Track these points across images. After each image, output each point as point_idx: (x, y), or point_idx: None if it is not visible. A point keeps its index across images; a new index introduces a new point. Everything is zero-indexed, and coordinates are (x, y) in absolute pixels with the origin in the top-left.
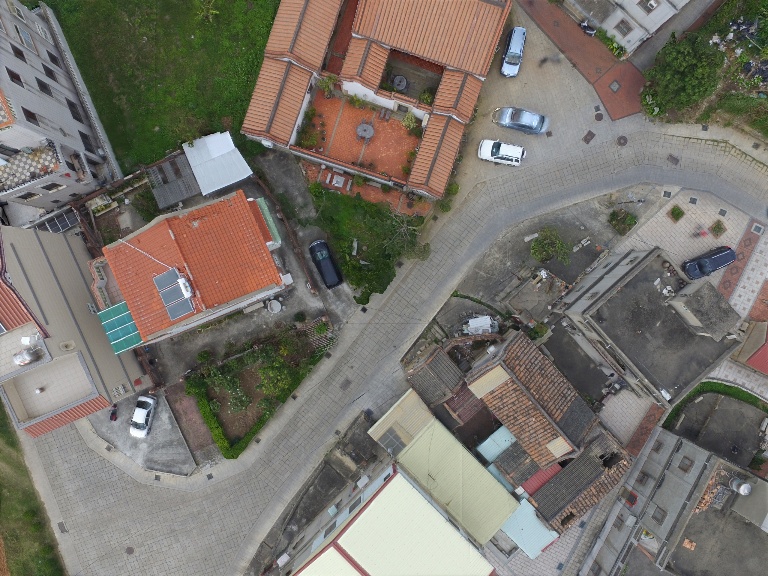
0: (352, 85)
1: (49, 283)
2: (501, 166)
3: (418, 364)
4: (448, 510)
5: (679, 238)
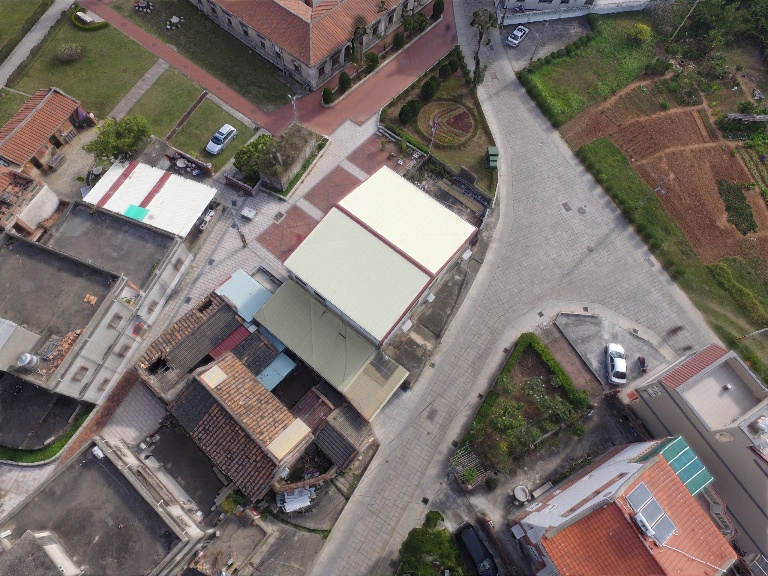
0: None
1: (765, 502)
2: None
3: None
4: (324, 307)
5: None
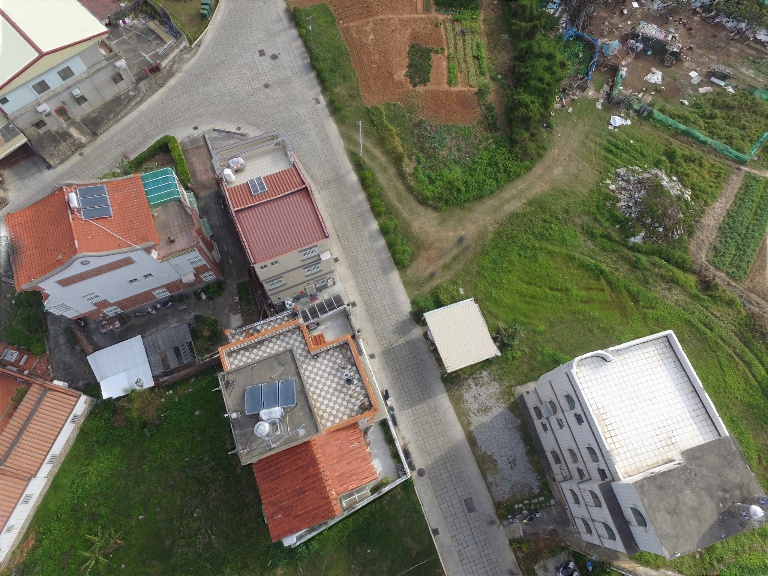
0: None
1: None
2: None
3: None
4: None
5: None
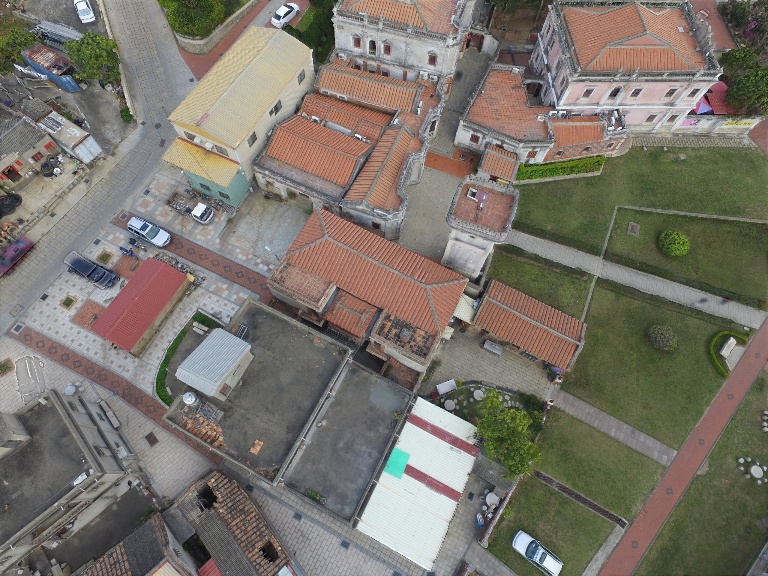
0: None
1: None
2: None
3: None
4: None
5: (2, 406)
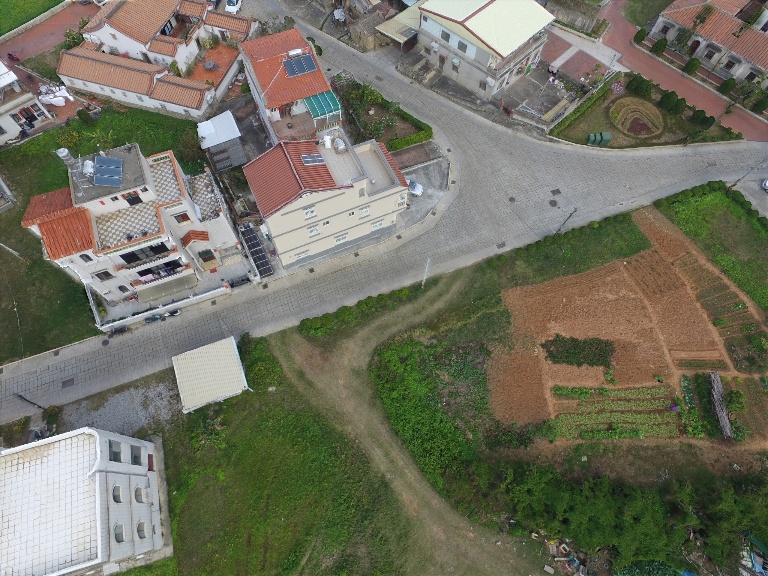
0: (179, 56)
1: None
2: (242, 8)
3: (360, 27)
4: None
5: None
